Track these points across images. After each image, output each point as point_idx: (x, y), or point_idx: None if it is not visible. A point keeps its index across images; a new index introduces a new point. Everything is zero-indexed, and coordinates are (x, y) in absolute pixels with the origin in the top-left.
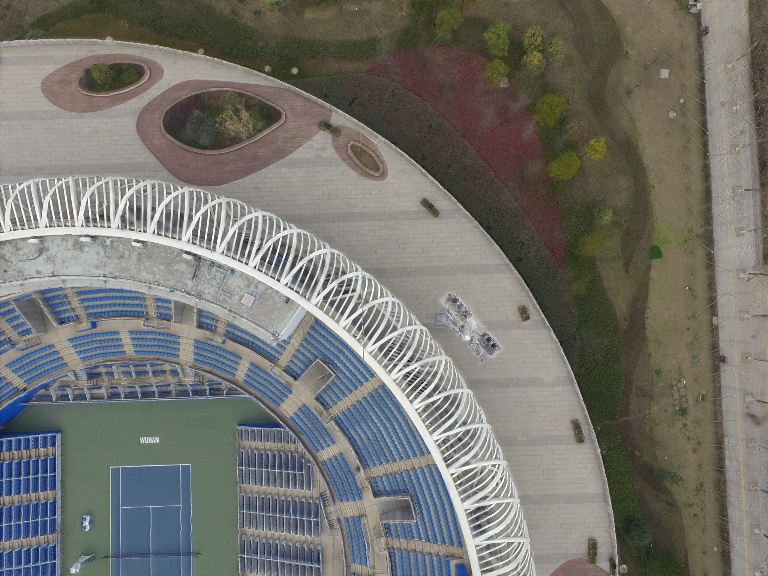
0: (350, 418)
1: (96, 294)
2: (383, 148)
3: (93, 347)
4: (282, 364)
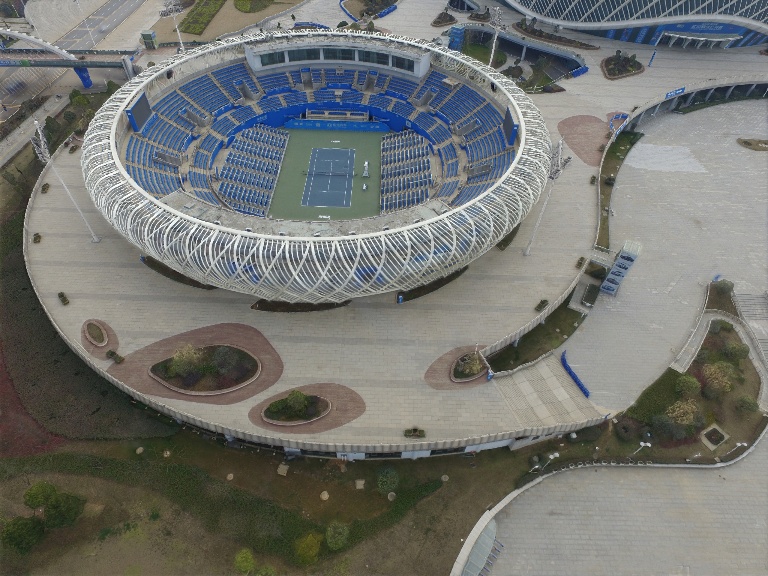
0: None
1: None
2: (77, 341)
3: None
4: None
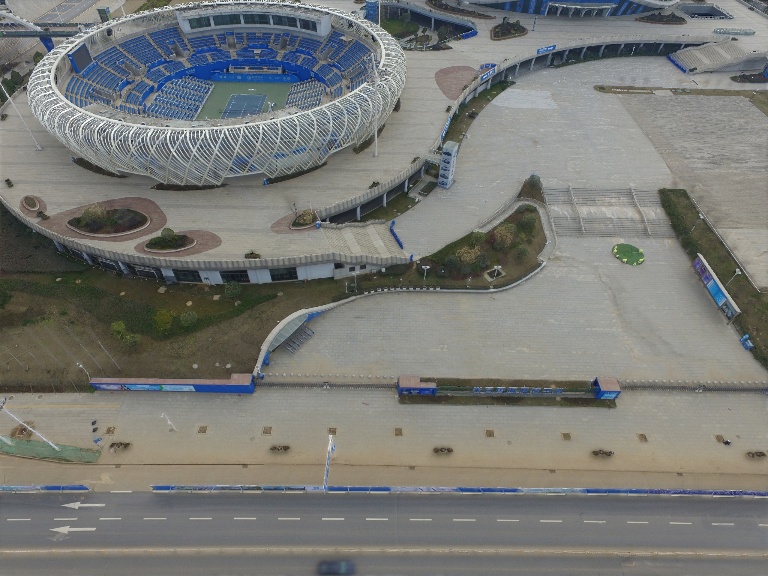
0: None
1: None
2: (16, 208)
3: None
4: None
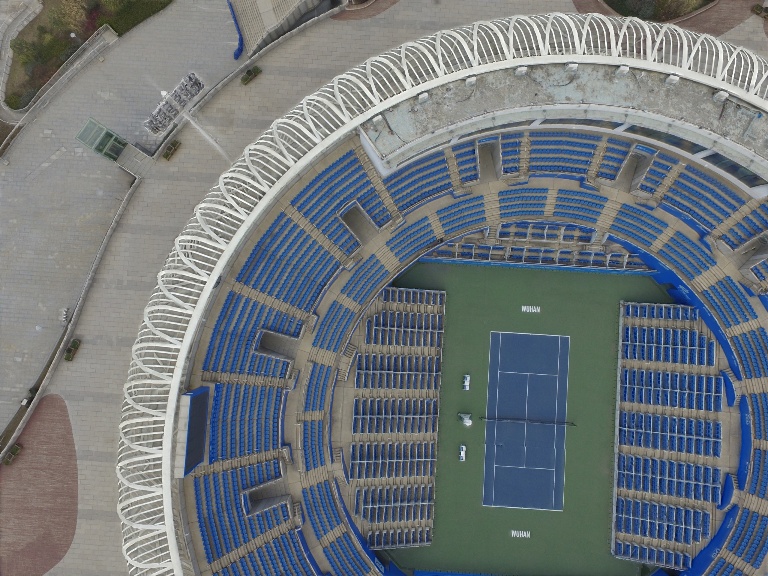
0: None
1: (548, 146)
2: None
3: (518, 203)
4: (717, 233)
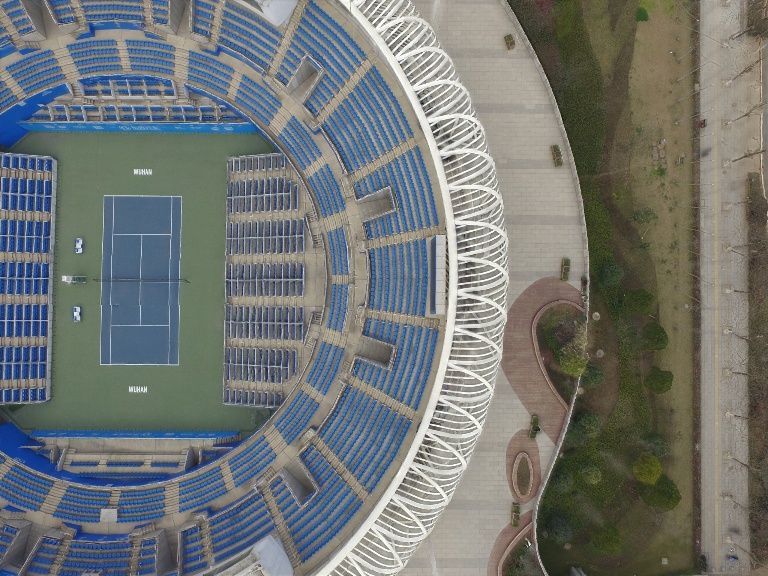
0: (337, 122)
1: None
2: None
3: (91, 58)
4: (273, 72)
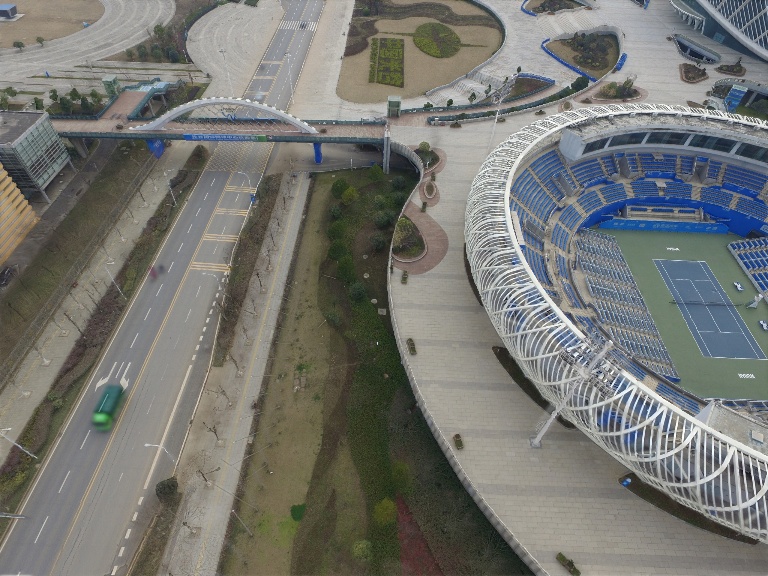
0: None
1: None
2: None
3: None
4: None
